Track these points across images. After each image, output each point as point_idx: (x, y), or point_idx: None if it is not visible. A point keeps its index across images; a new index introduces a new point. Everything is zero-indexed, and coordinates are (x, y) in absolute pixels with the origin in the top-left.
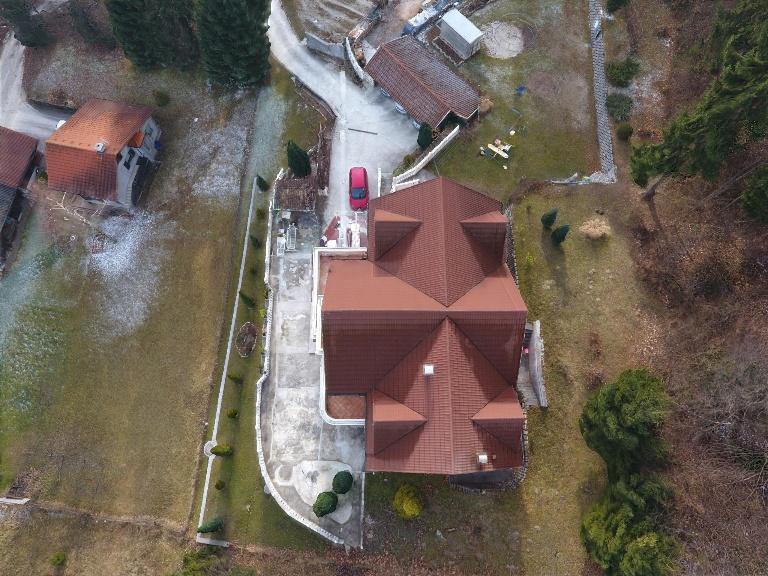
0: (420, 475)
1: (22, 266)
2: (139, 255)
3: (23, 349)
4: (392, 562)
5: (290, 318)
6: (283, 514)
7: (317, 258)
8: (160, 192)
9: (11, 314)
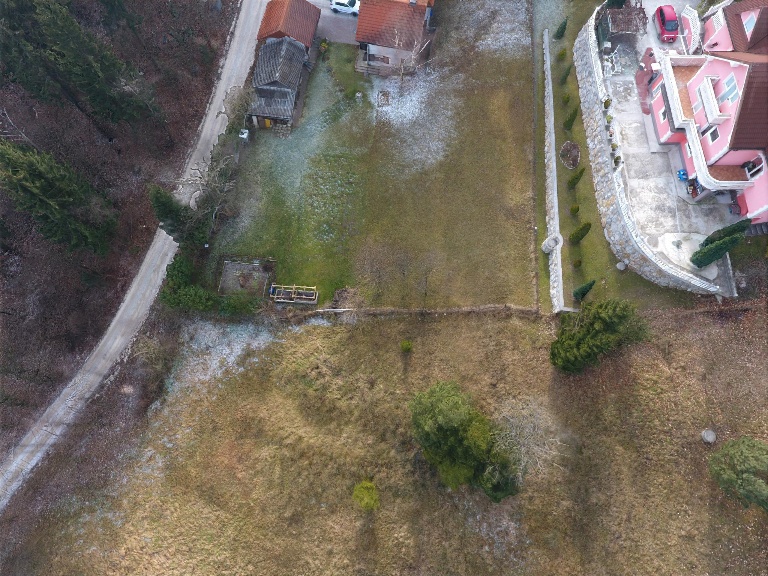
0: None
1: (309, 121)
2: (429, 104)
3: (320, 190)
4: None
5: (626, 126)
6: (641, 284)
7: None
8: (441, 52)
9: (304, 162)
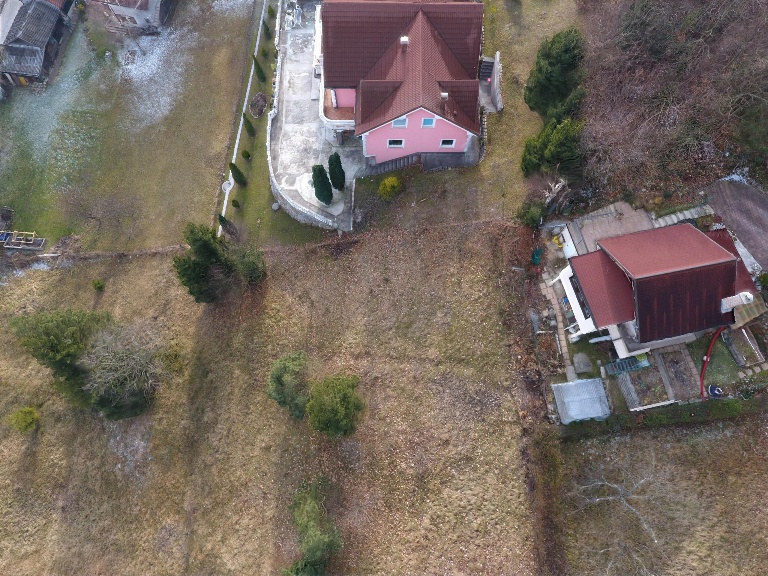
0: (400, 171)
1: (63, 79)
2: (166, 62)
3: (64, 144)
4: (376, 232)
5: (296, 75)
6: (288, 222)
7: (319, 13)
8: (184, 12)
9: (54, 117)
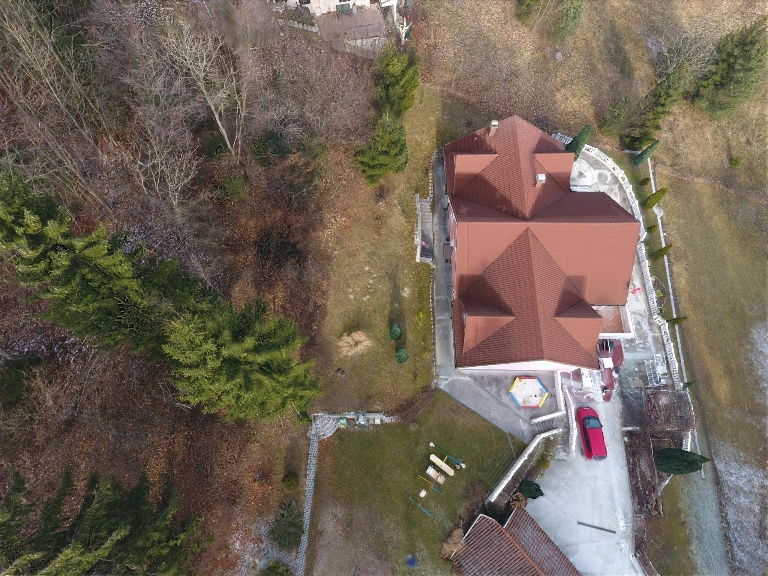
0: None
1: None
2: None
3: None
4: None
5: (630, 294)
6: None
7: (631, 326)
8: None
9: None
